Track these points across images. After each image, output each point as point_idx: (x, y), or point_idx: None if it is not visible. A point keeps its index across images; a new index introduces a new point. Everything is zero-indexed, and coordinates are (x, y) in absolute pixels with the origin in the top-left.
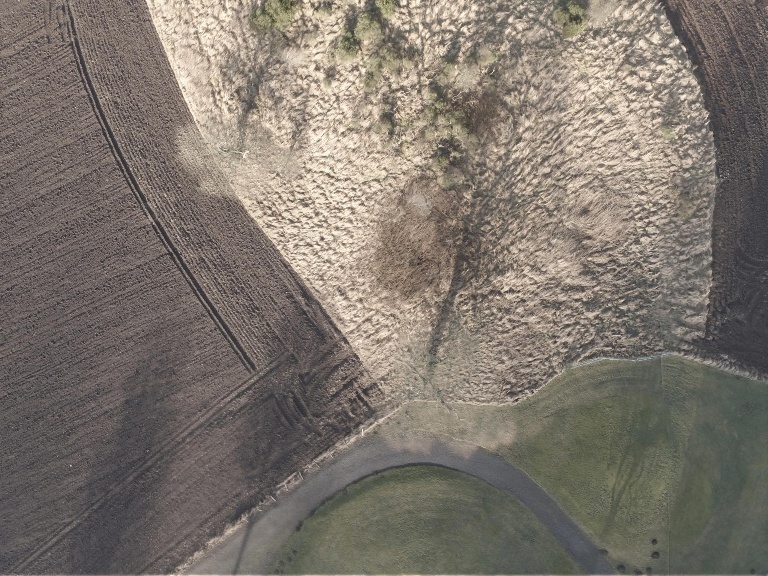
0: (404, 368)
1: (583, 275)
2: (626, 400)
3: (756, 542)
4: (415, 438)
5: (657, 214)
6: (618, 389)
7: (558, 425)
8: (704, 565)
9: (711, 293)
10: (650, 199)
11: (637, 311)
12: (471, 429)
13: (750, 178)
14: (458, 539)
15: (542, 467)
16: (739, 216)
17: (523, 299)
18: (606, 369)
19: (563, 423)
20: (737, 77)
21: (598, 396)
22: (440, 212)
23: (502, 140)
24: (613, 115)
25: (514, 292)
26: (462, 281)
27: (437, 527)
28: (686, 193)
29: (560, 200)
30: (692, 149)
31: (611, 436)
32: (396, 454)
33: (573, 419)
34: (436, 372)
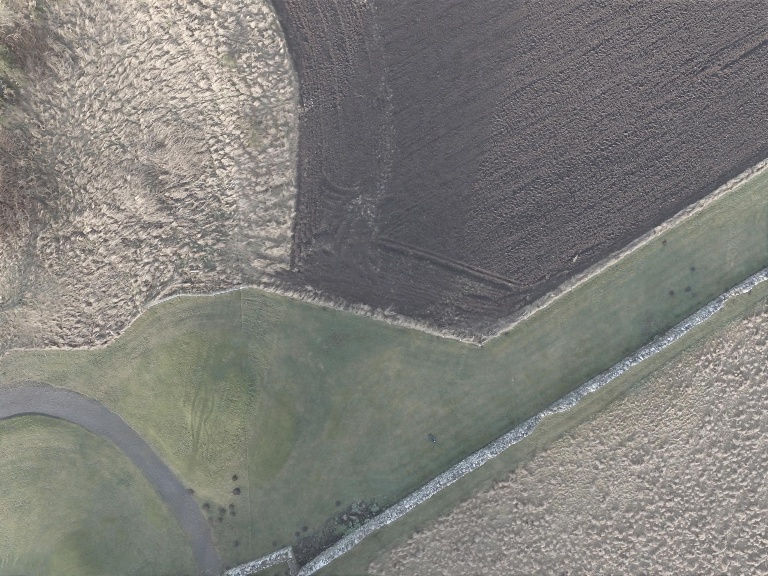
0: (3, 317)
1: (160, 211)
2: (202, 336)
3: (342, 474)
4: (19, 388)
5: (230, 145)
6: (196, 325)
7: (143, 365)
8: (285, 499)
9: (296, 224)
10: (225, 130)
11: (214, 245)
12: (68, 375)
13: (336, 106)
14: (52, 487)
15: (132, 409)
16: (324, 145)
17: (106, 239)
18: (186, 306)
19: (147, 363)
20: (318, 3)
21: (177, 333)
22: (8, 153)
23: (64, 75)
24: (178, 45)
25: (94, 232)
26: (41, 223)
27: (34, 476)
28: (258, 122)
29: (134, 135)
30: (260, 77)
31: (187, 373)
32: (3, 405)
33: (156, 358)
34: (28, 319)
